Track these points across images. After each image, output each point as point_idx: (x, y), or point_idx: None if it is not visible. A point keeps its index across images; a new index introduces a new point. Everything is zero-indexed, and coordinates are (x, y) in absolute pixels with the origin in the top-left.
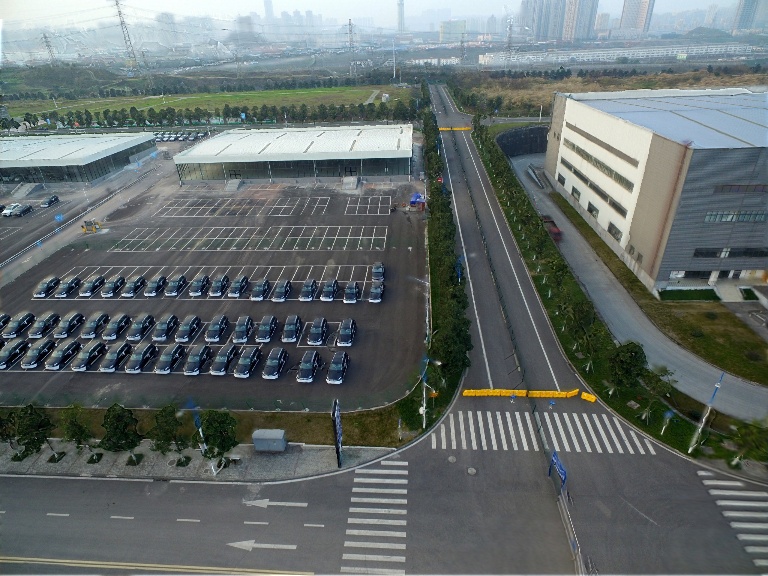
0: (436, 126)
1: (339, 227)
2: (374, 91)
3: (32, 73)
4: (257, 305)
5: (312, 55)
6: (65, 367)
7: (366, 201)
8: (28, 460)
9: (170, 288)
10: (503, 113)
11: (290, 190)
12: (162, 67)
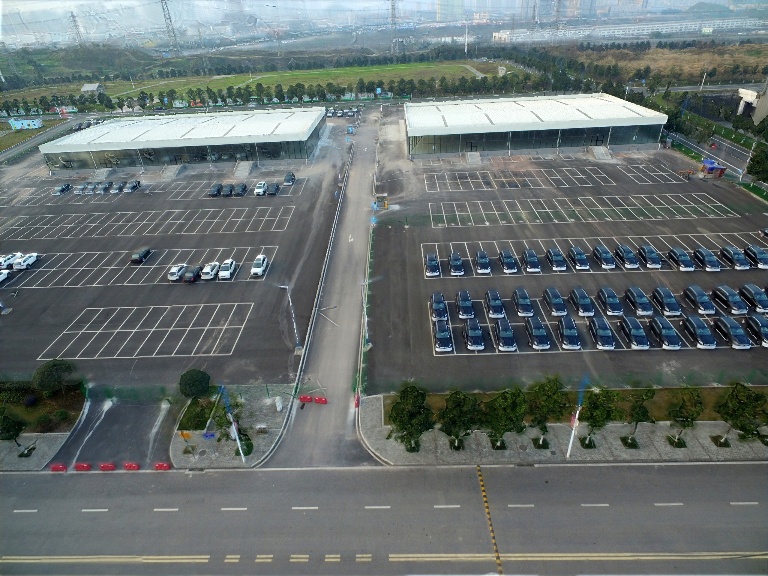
0: (642, 93)
1: (654, 196)
2: (464, 66)
3: (68, 54)
4: (694, 275)
5: (353, 32)
6: (581, 346)
7: (642, 170)
8: (693, 446)
9: (582, 261)
10: (646, 83)
11: (540, 161)
12: (199, 47)
